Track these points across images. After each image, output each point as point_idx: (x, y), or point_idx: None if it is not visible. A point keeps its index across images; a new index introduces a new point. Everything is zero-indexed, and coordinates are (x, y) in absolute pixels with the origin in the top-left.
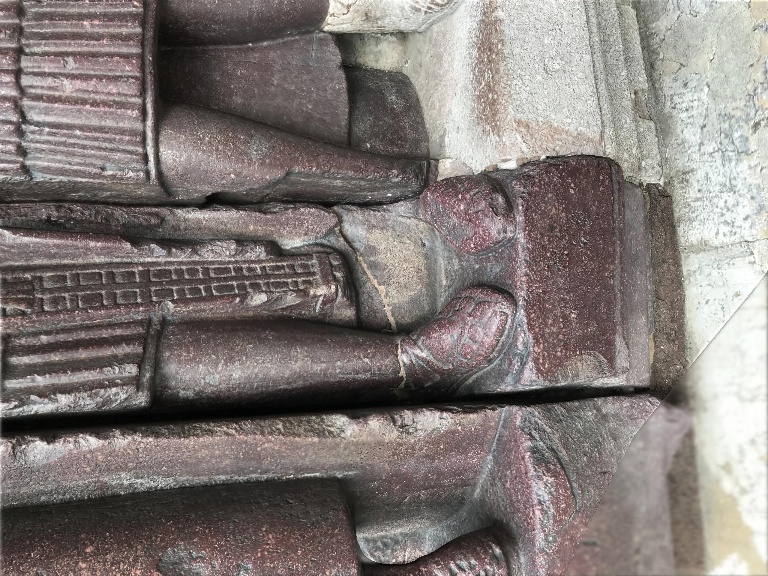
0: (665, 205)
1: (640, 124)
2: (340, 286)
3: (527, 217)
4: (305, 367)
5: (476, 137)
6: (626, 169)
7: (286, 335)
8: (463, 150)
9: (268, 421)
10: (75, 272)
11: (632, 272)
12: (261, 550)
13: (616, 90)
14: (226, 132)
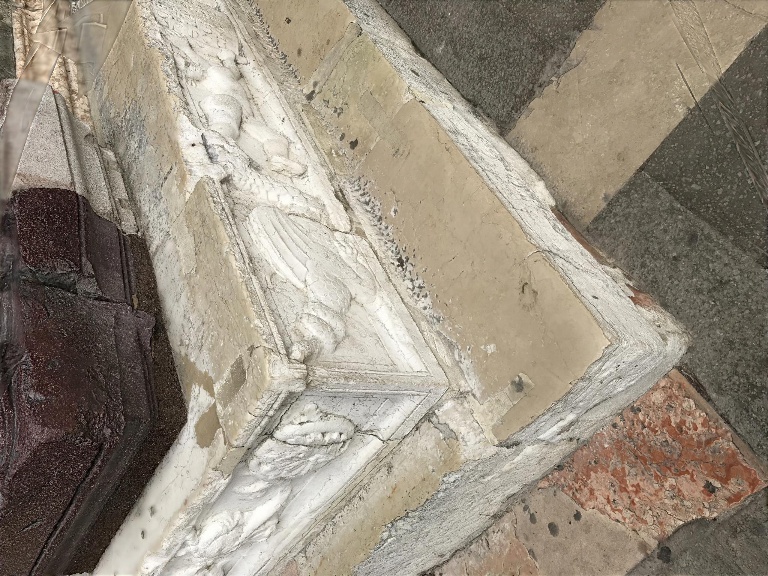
0: (141, 242)
1: (122, 210)
2: None
3: (20, 204)
4: None
5: None
6: (102, 213)
7: None
8: None
9: None
10: None
11: (108, 253)
12: None
13: (97, 187)
14: None
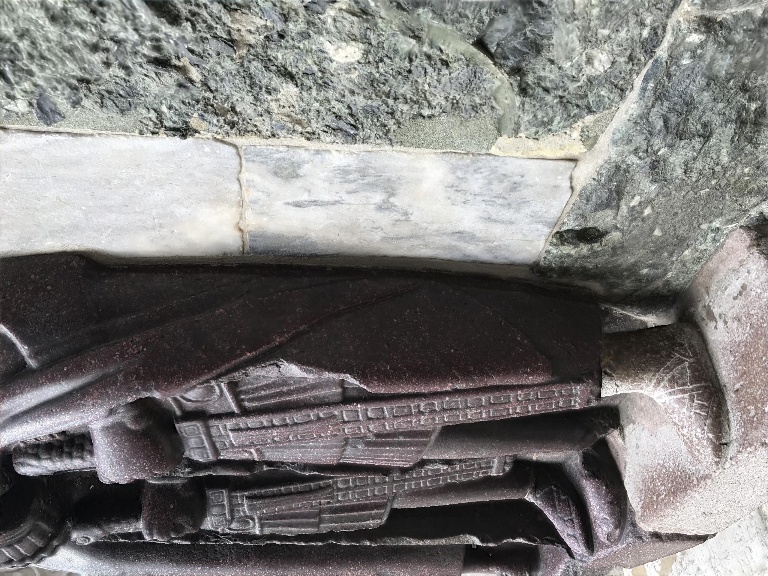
0: None
1: None
2: None
3: None
4: None
5: (637, 480)
6: None
7: (462, 494)
8: (630, 460)
9: (438, 540)
10: (354, 477)
11: None
12: (421, 573)
13: None
14: None
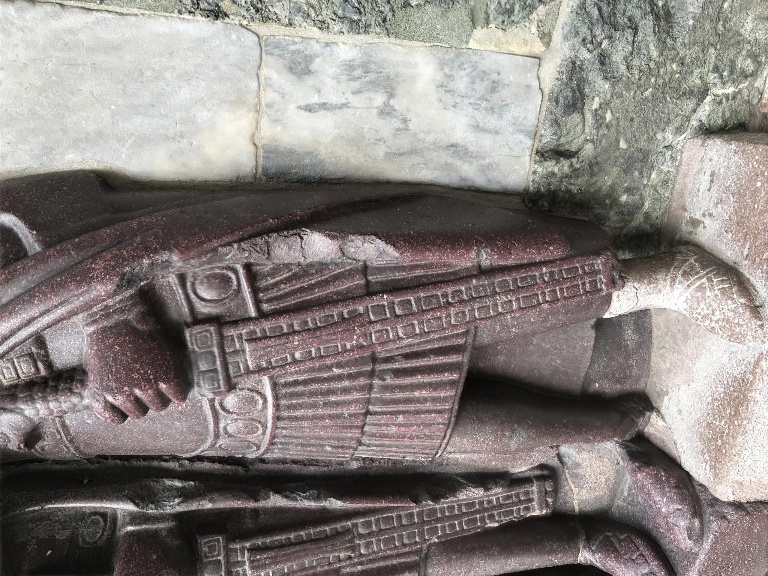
0: None
1: None
2: (549, 509)
3: (712, 547)
4: (514, 568)
5: (694, 446)
6: None
7: (506, 549)
8: (678, 433)
9: None
10: (377, 517)
11: None
12: None
13: None
14: (496, 432)
